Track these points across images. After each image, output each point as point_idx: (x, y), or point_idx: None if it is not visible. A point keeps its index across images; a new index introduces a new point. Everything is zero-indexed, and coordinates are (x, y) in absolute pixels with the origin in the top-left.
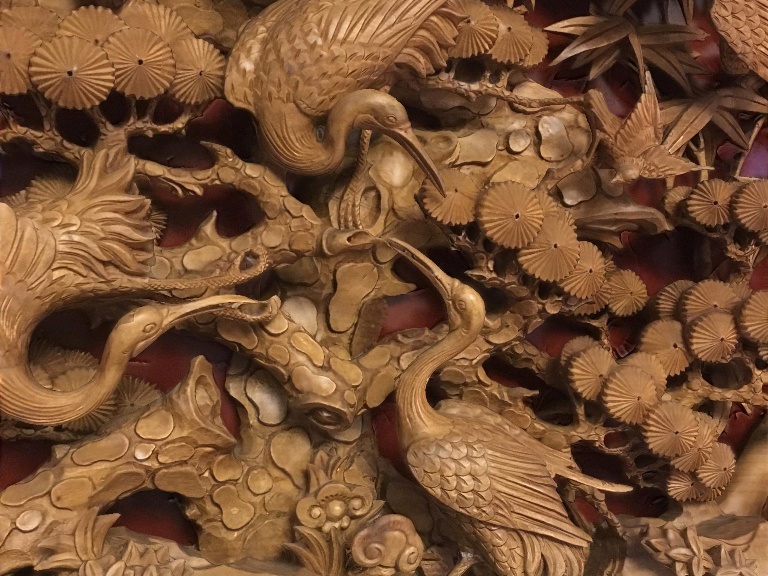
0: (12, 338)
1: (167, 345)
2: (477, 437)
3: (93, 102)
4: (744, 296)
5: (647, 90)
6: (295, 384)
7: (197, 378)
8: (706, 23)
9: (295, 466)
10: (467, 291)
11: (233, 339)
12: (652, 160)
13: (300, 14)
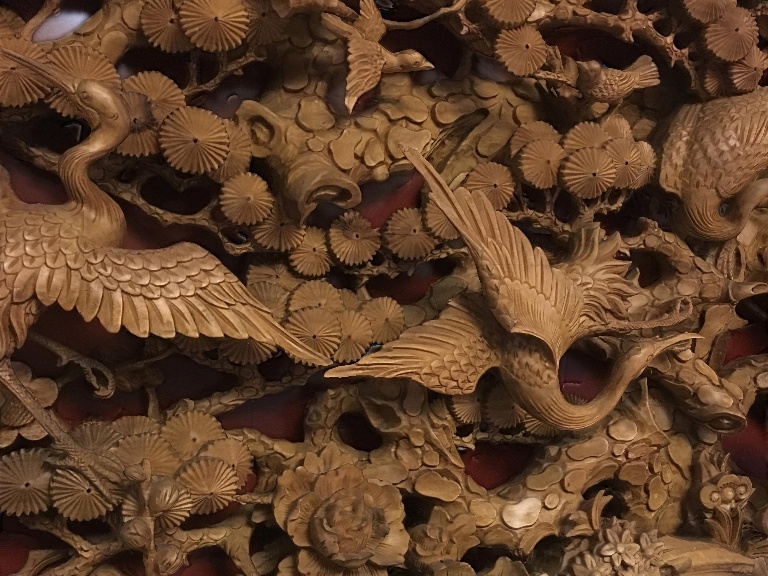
0: (558, 367)
1: (594, 370)
2: None
3: (599, 194)
4: None
5: None
6: (701, 399)
7: None
8: None
9: (684, 462)
10: None
11: (651, 365)
12: None
13: (718, 123)
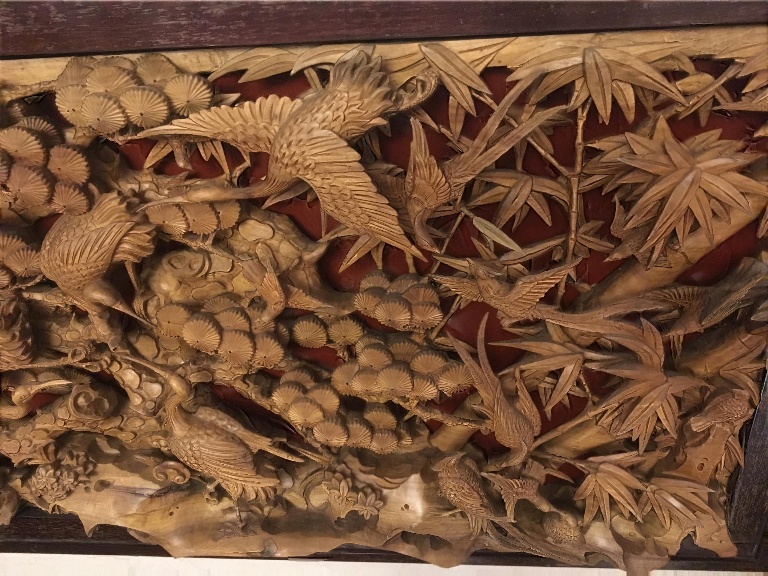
0: None
1: None
2: (197, 440)
3: None
4: (409, 351)
5: (268, 270)
6: None
7: (75, 395)
8: (393, 156)
9: None
10: (172, 381)
11: None
12: (295, 298)
13: (54, 243)
